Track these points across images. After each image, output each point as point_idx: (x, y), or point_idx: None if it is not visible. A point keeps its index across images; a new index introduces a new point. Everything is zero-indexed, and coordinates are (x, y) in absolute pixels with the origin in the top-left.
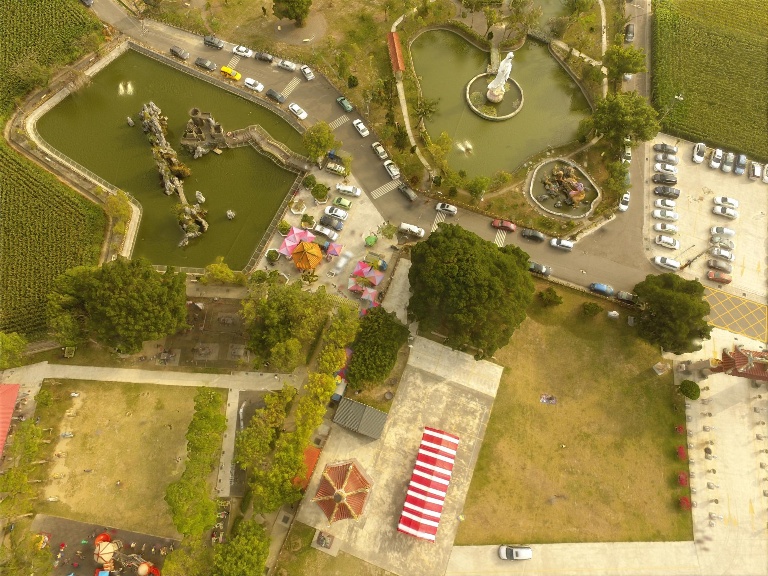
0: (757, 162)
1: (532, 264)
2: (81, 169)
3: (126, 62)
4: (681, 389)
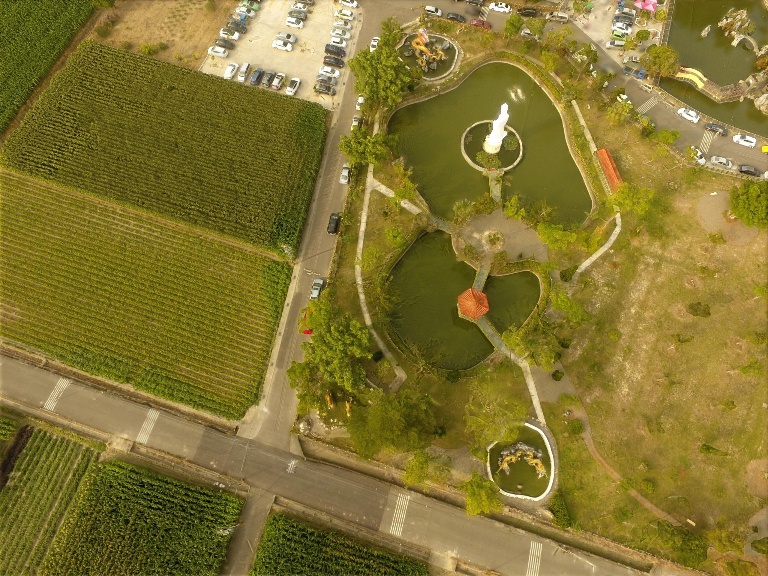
0: None
1: None
2: None
3: None
4: None
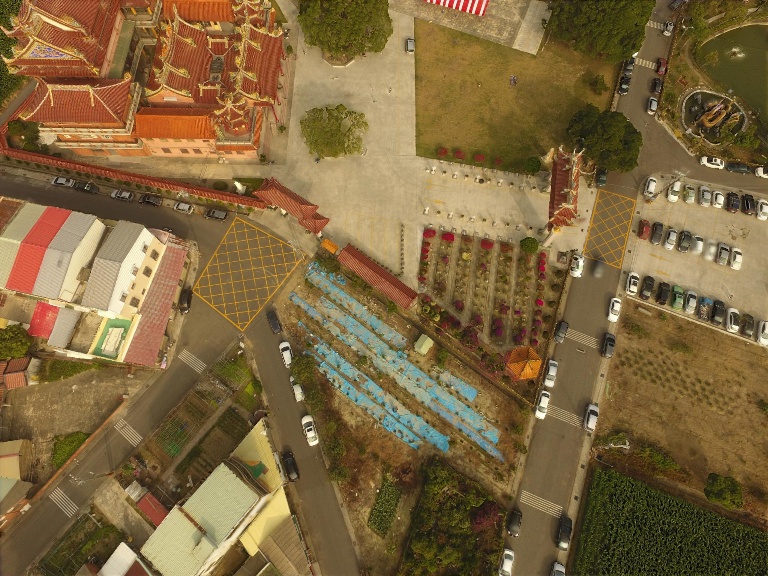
0: None
1: (628, 78)
2: None
3: None
4: None
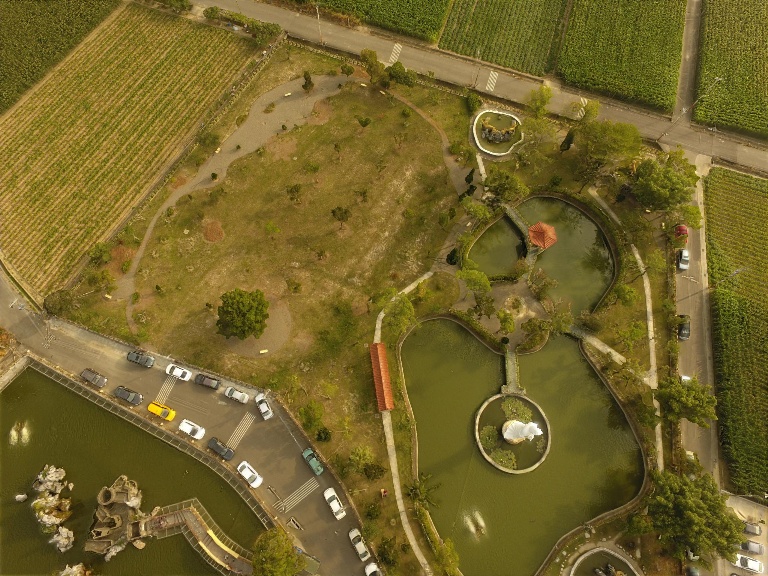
0: None
1: None
2: None
3: (23, 387)
4: None
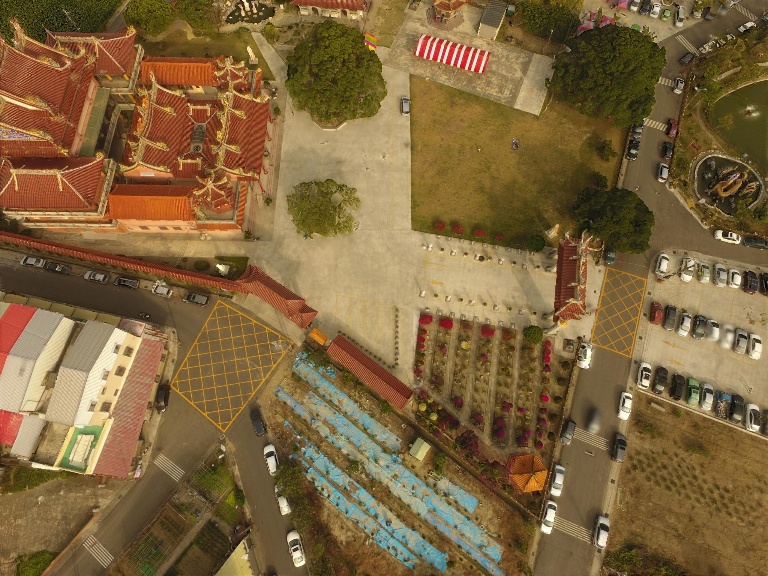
0: None
1: (637, 142)
2: None
3: None
4: None
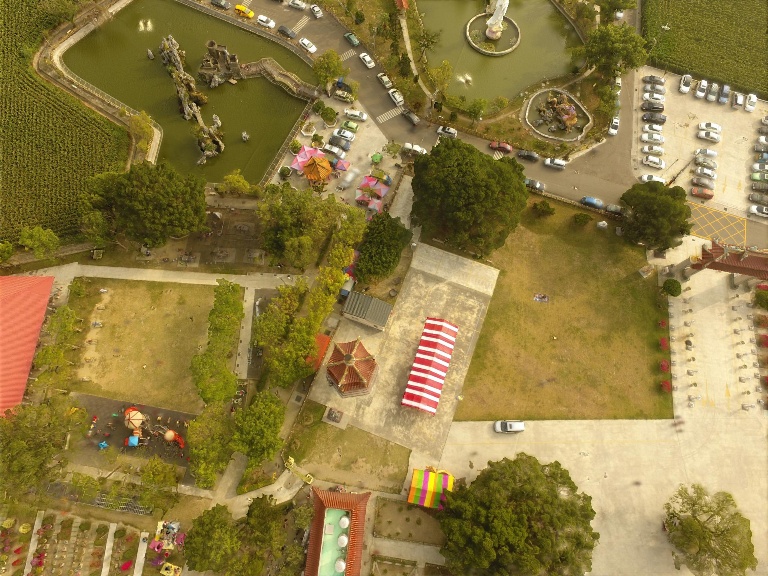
0: (740, 93)
1: (527, 180)
2: (105, 96)
3: (145, 2)
4: (664, 287)
